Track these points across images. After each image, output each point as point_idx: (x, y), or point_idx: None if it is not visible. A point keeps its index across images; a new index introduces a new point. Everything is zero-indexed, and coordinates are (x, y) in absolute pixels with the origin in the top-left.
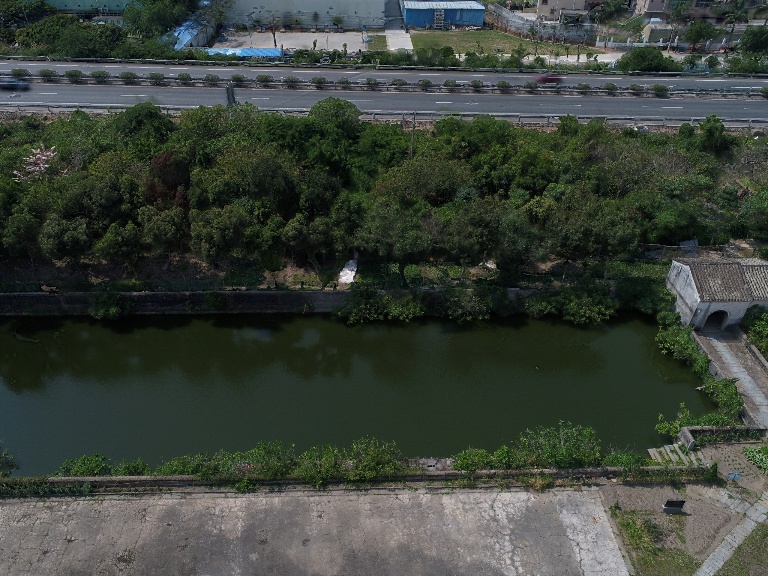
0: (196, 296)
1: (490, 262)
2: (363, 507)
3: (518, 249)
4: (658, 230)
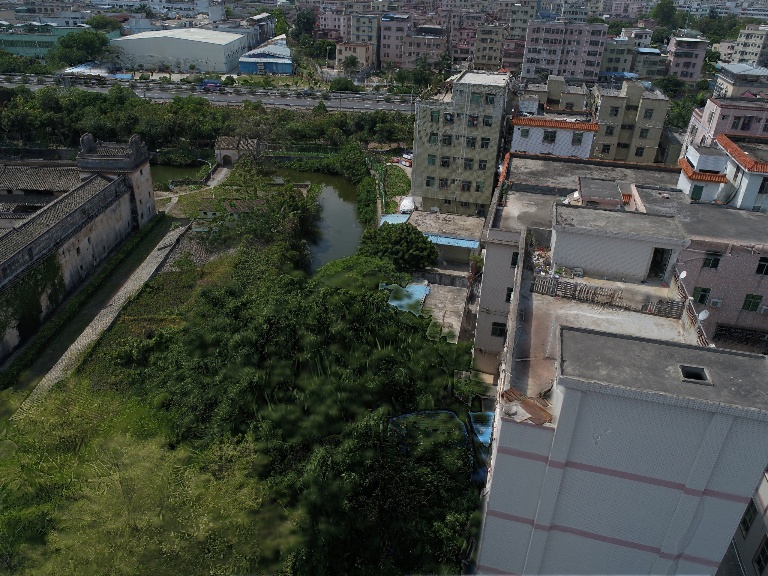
0: (7, 149)
1: None
2: None
3: (146, 129)
4: None
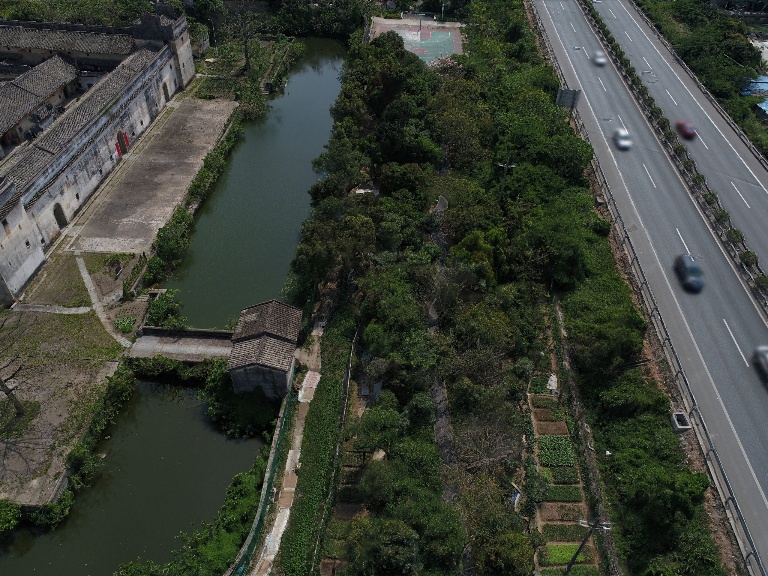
0: None
1: (371, 254)
2: None
3: None
4: None
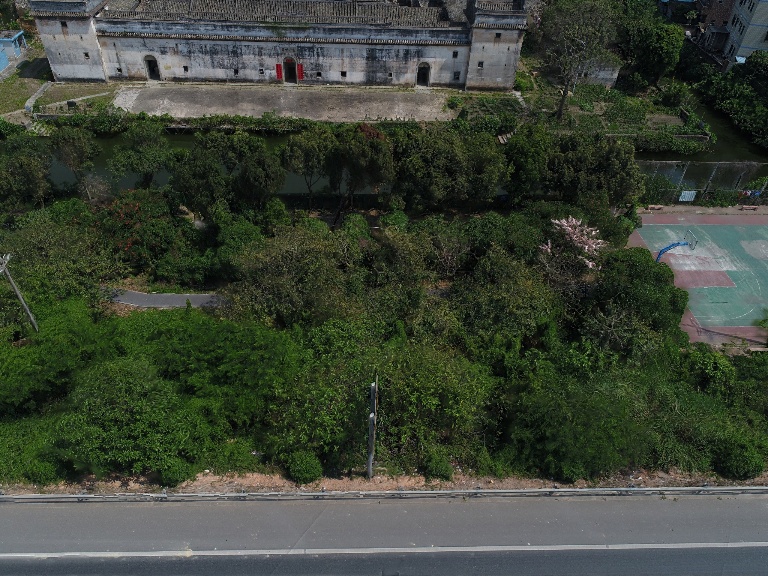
0: None
1: None
2: None
3: None
4: None
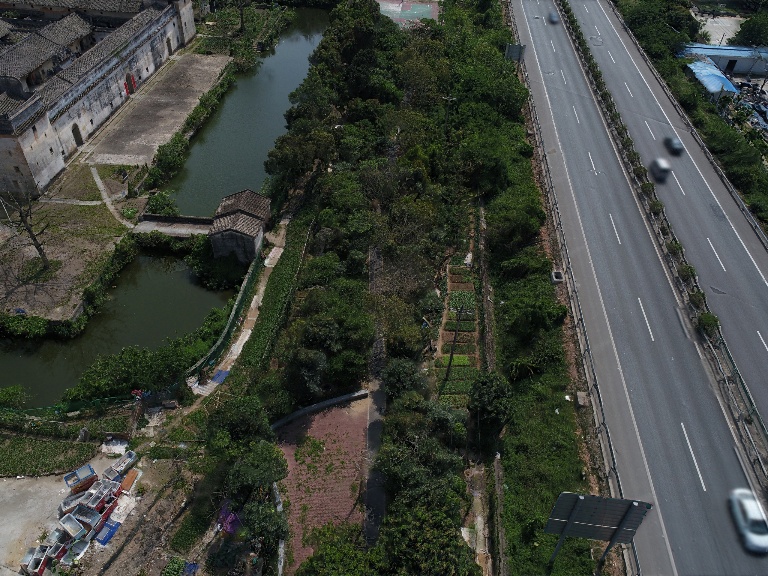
0: None
1: None
2: (179, 120)
3: None
4: None
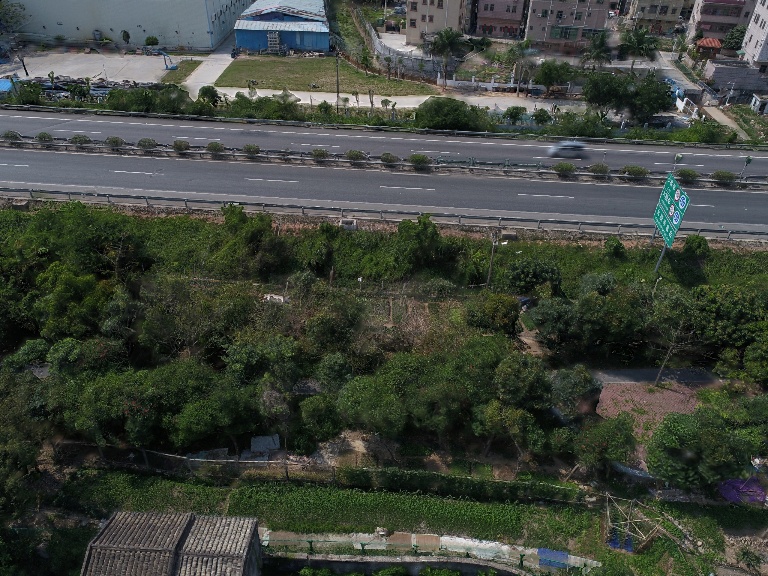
0: None
1: None
2: None
3: None
4: (182, 432)
